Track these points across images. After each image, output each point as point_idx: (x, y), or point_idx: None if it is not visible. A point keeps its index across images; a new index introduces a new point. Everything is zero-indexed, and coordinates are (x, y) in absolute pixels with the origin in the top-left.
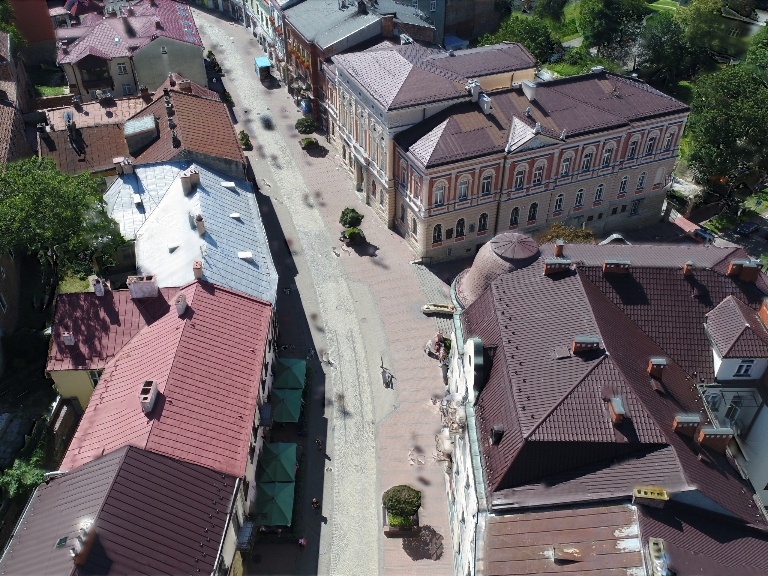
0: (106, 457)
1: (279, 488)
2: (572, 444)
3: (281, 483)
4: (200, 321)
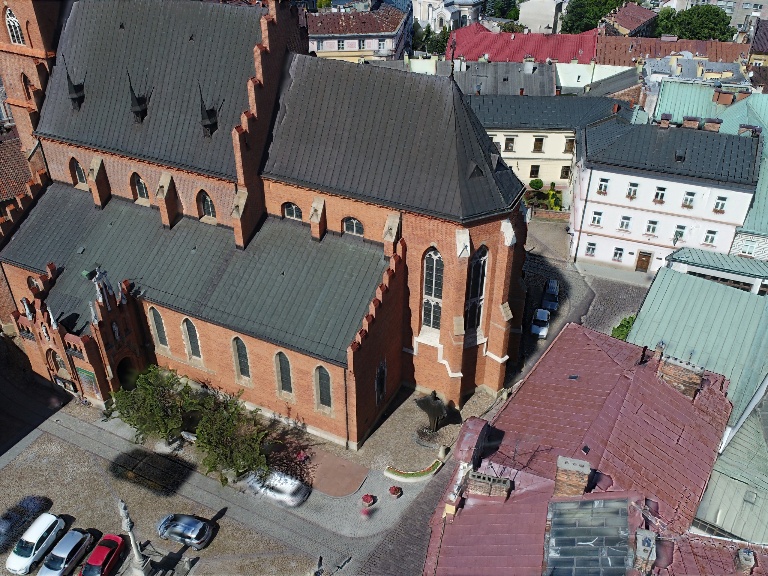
0: None
1: None
2: None
3: None
4: None
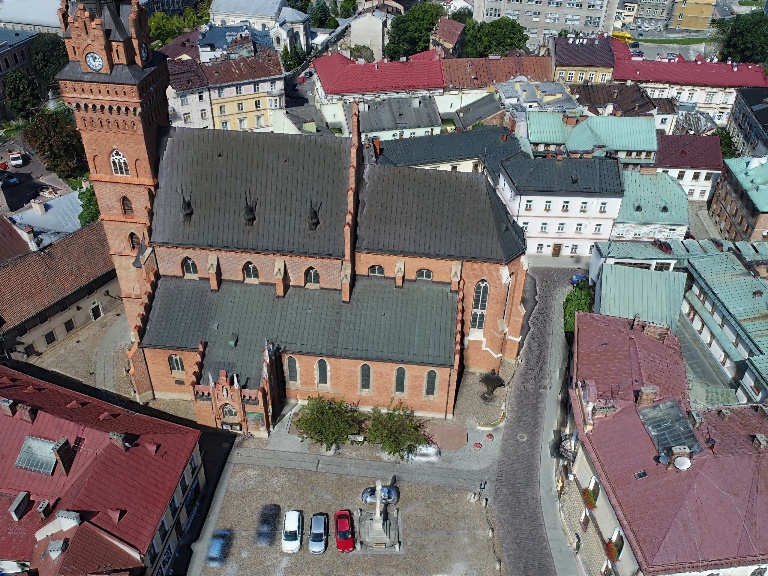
0: None
1: None
2: (190, 67)
3: None
4: None
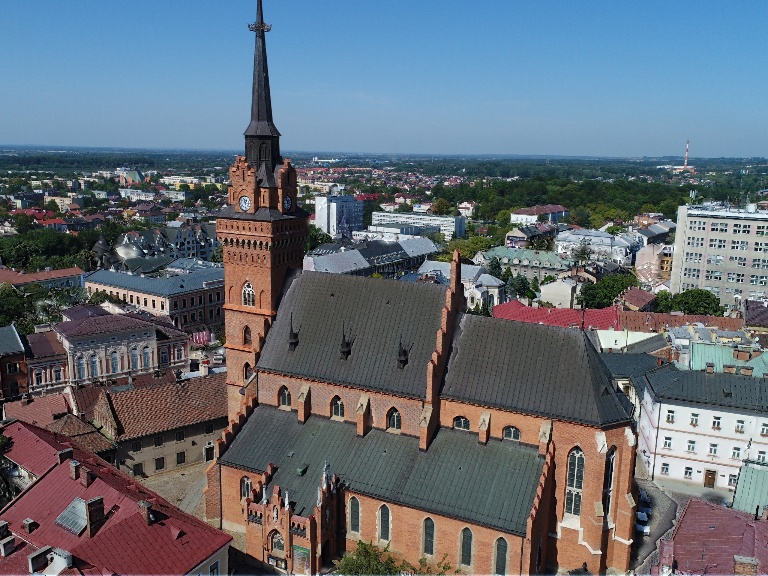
0: None
1: None
2: None
3: None
4: None
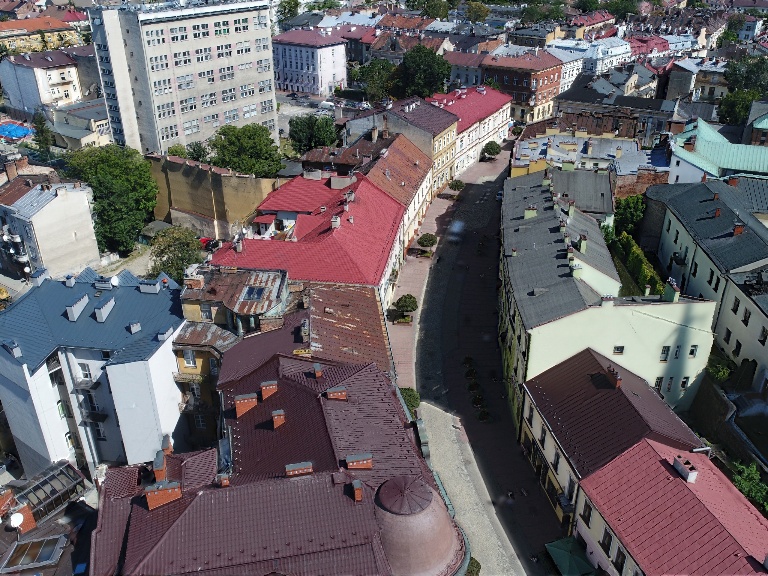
0: (666, 433)
1: (575, 568)
2: None
3: (577, 575)
4: (741, 568)
